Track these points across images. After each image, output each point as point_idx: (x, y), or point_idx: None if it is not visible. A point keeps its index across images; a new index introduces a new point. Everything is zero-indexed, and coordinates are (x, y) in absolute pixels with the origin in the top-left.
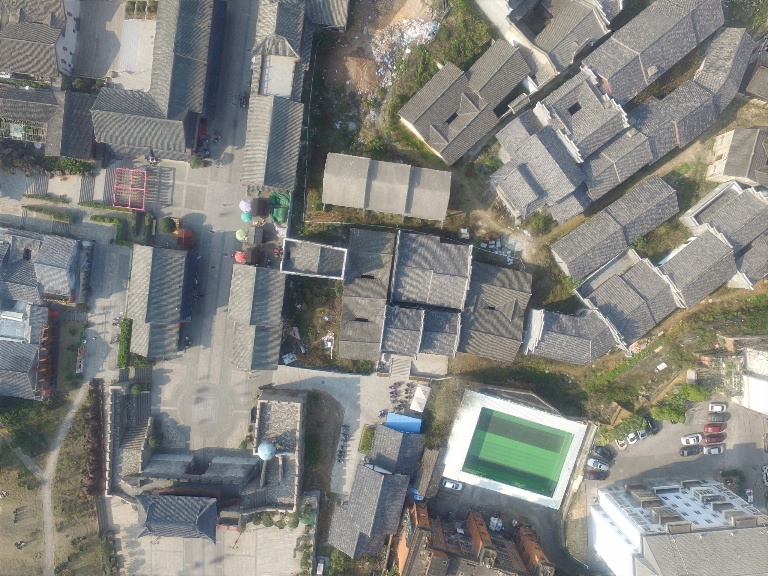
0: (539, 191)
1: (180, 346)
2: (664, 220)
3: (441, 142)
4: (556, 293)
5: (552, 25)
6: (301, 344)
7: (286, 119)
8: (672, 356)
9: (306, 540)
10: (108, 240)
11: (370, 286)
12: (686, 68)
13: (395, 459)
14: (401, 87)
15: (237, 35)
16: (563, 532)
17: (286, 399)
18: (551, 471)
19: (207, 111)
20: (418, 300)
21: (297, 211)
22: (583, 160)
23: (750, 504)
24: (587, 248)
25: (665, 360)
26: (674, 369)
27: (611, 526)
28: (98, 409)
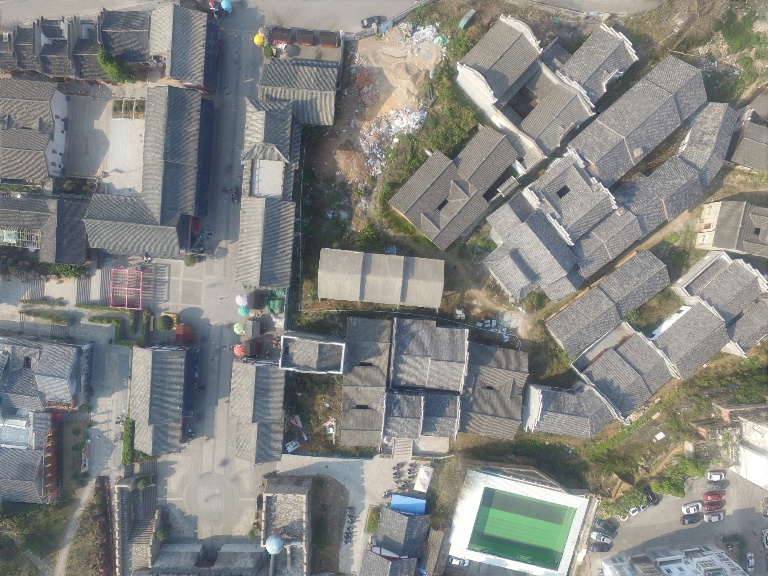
0: (532, 276)
1: (183, 438)
2: (656, 293)
3: (433, 229)
4: (553, 367)
5: (537, 109)
6: (303, 431)
7: (278, 219)
8: (669, 425)
9: None
10: (107, 340)
11: (369, 374)
12: (671, 142)
13: (401, 542)
14: (391, 175)
15: (225, 131)
16: None
17: (291, 490)
18: (555, 543)
19: (199, 210)
20: (417, 384)
21: (293, 302)
22: None
23: (751, 569)
24: (581, 326)
25: (663, 429)
26: (672, 440)
27: None
28: (105, 505)
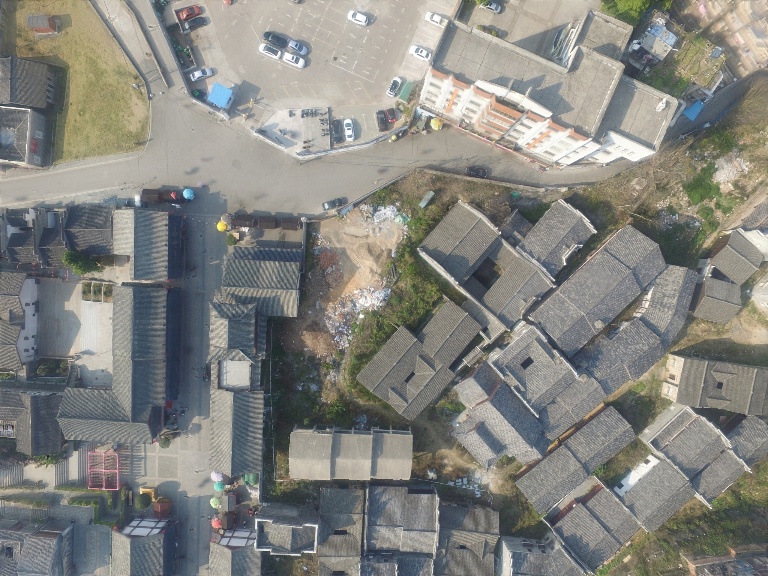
0: (498, 448)
1: None
2: (622, 448)
3: (401, 402)
4: (524, 520)
5: (499, 283)
6: None
7: (247, 409)
8: (639, 574)
9: None
10: (87, 520)
11: (344, 543)
12: (633, 303)
13: None
14: (358, 347)
15: (194, 311)
16: None
17: None
18: None
19: (171, 395)
20: (391, 547)
21: (267, 473)
22: (538, 416)
23: None
24: (550, 487)
25: None
26: None
27: None
28: None
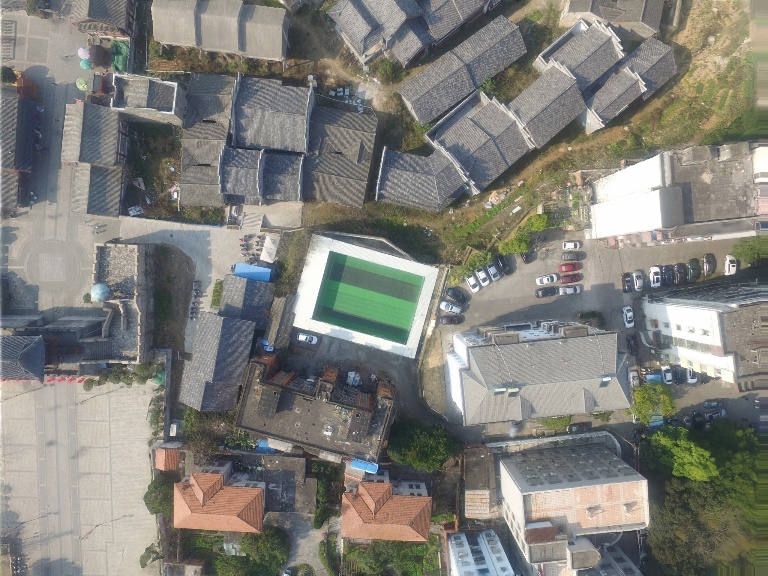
0: (374, 24)
1: (25, 202)
2: (512, 61)
3: None
4: (408, 141)
5: None
6: (147, 195)
7: None
8: (526, 198)
9: (158, 401)
10: None
11: (210, 129)
12: None
13: (241, 306)
14: None
15: None
16: (419, 381)
17: (125, 244)
18: (408, 322)
19: None
20: (262, 145)
21: (139, 60)
22: None
23: None
24: (431, 87)
25: (520, 204)
26: (525, 208)
27: (455, 359)
28: None
